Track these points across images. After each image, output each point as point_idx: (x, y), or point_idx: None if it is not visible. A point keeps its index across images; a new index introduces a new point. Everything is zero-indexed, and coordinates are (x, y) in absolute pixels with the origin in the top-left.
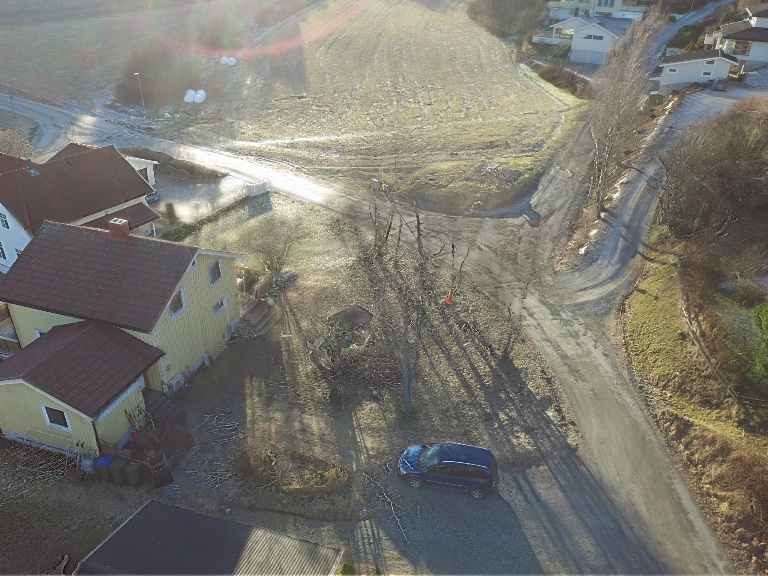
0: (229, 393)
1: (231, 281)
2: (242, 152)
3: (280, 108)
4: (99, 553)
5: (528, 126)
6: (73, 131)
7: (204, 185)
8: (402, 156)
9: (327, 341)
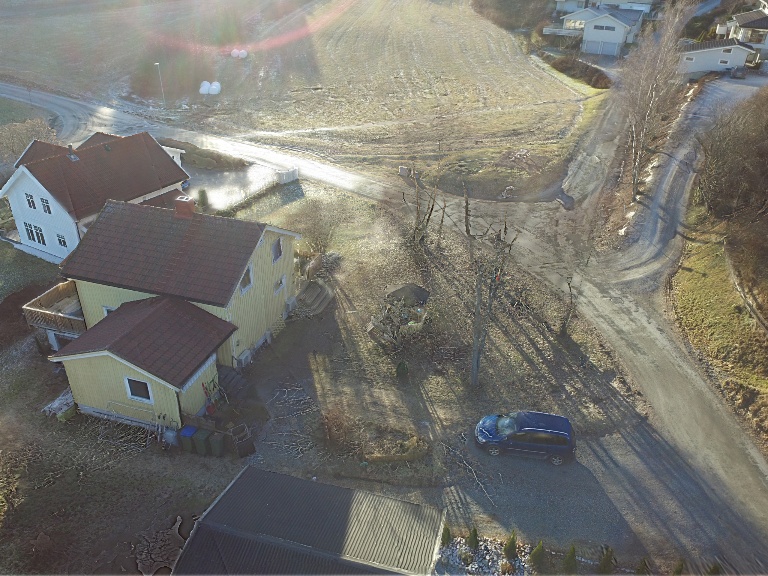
0: (295, 369)
1: (289, 260)
2: (265, 142)
3: (296, 99)
4: (212, 513)
5: (549, 114)
6: (93, 122)
7: (232, 173)
8: (427, 144)
9: (385, 319)
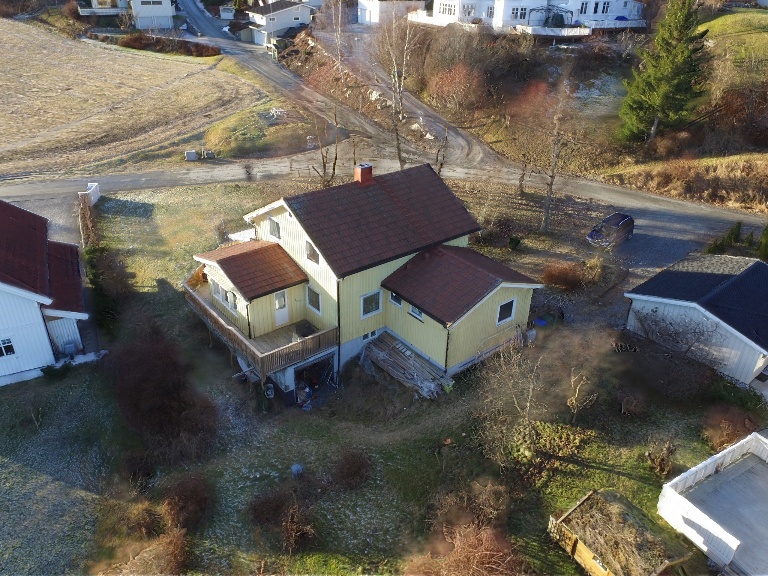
0: None
1: None
2: None
3: None
4: None
5: (217, 83)
6: None
7: None
8: (160, 131)
9: None
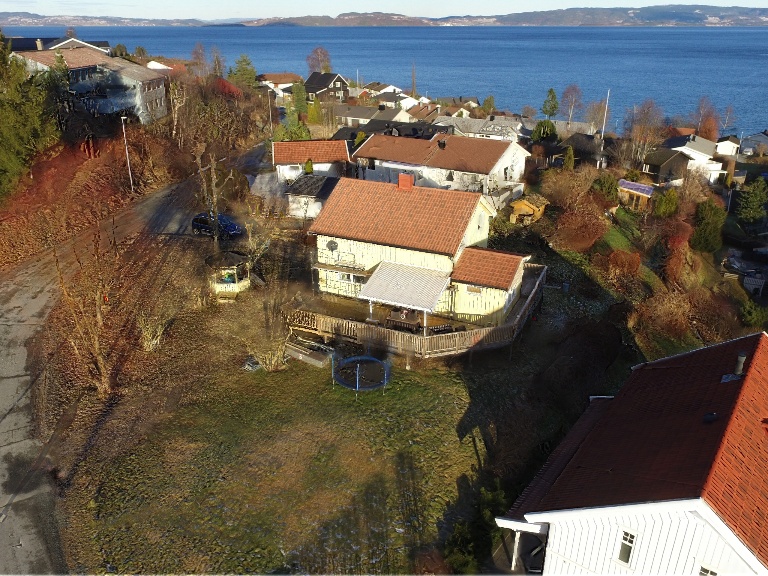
0: None
1: None
2: None
3: None
4: None
5: None
6: None
7: None
8: None
9: None
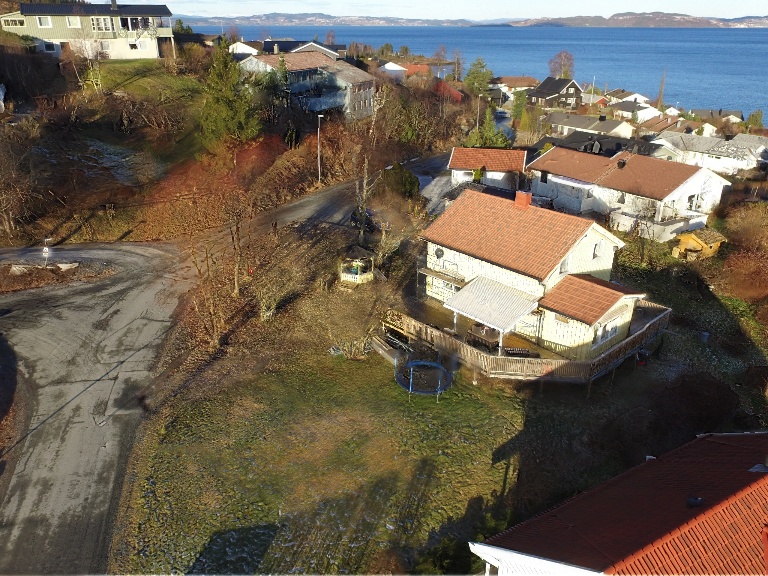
0: None
1: None
2: None
3: None
4: None
5: None
6: None
7: None
8: None
9: None
